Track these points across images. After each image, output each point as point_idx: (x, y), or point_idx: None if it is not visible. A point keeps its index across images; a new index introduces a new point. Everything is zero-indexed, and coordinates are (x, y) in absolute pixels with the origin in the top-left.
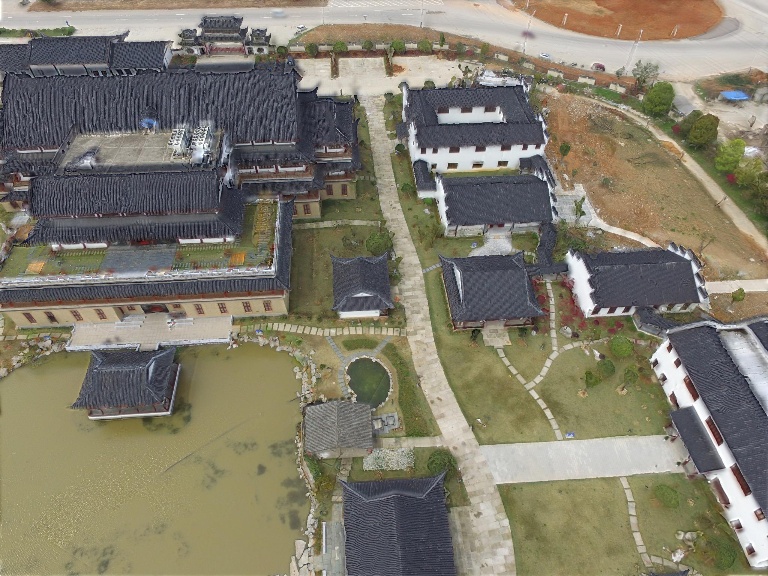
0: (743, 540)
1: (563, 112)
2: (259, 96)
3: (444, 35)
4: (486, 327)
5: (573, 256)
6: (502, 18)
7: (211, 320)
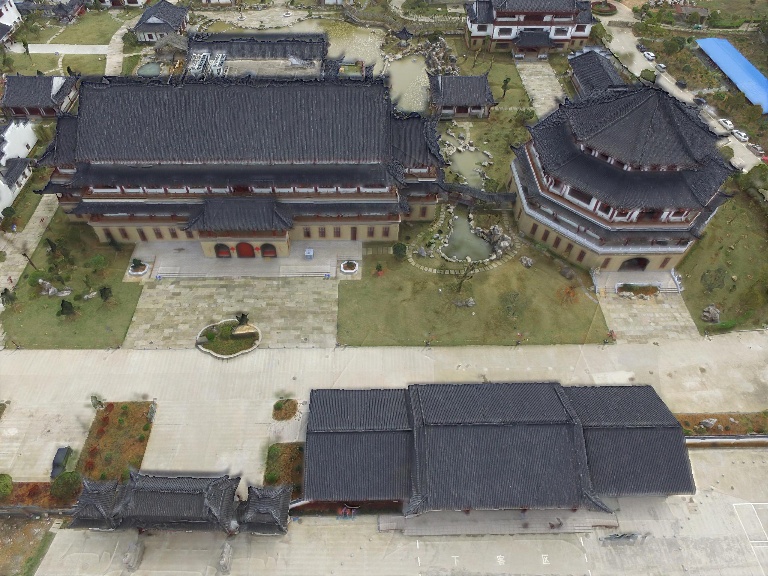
0: None
1: None
2: None
3: None
4: None
5: None
6: None
7: None
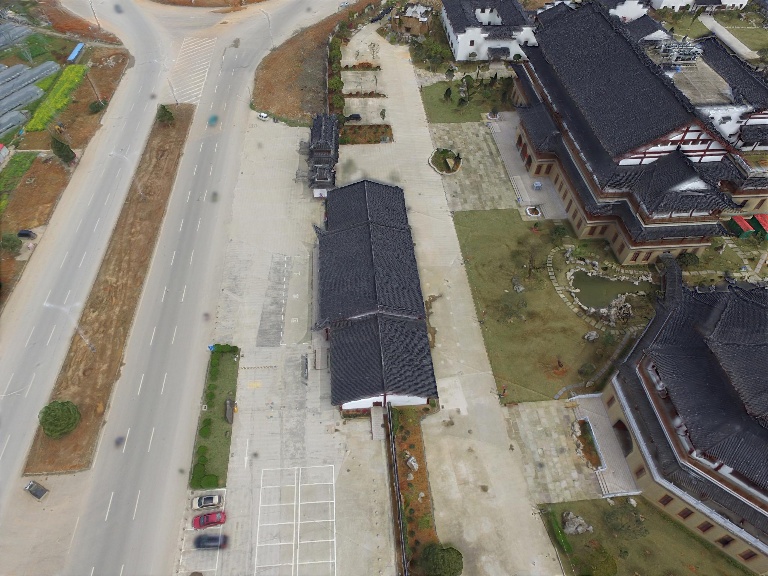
0: (738, 6)
1: (434, 8)
2: None
3: (294, 41)
4: None
5: (616, 8)
6: (260, 14)
7: None
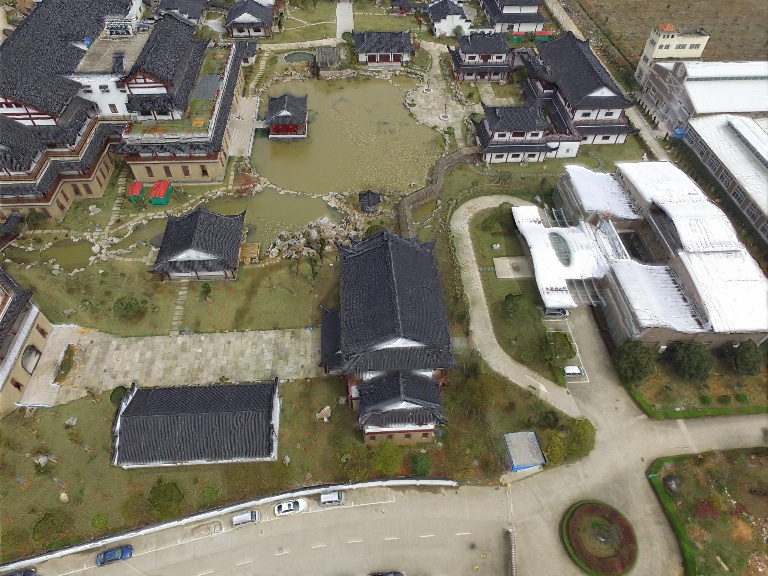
0: None
1: None
2: (80, 2)
3: None
4: (272, 30)
5: None
6: None
7: (241, 105)
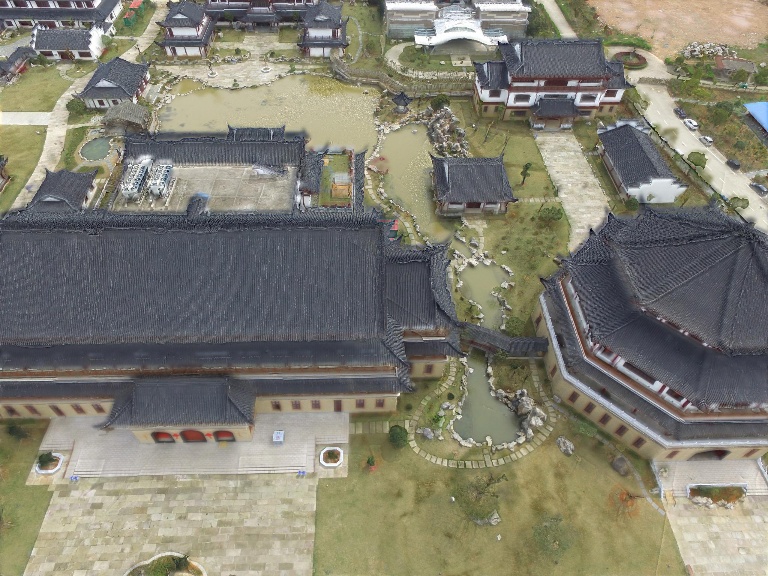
0: None
1: None
2: None
3: None
4: None
5: None
6: None
7: None
